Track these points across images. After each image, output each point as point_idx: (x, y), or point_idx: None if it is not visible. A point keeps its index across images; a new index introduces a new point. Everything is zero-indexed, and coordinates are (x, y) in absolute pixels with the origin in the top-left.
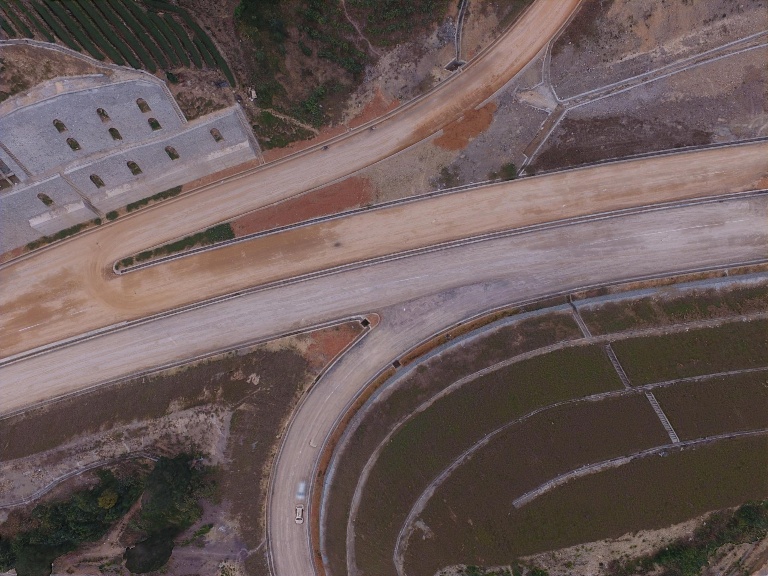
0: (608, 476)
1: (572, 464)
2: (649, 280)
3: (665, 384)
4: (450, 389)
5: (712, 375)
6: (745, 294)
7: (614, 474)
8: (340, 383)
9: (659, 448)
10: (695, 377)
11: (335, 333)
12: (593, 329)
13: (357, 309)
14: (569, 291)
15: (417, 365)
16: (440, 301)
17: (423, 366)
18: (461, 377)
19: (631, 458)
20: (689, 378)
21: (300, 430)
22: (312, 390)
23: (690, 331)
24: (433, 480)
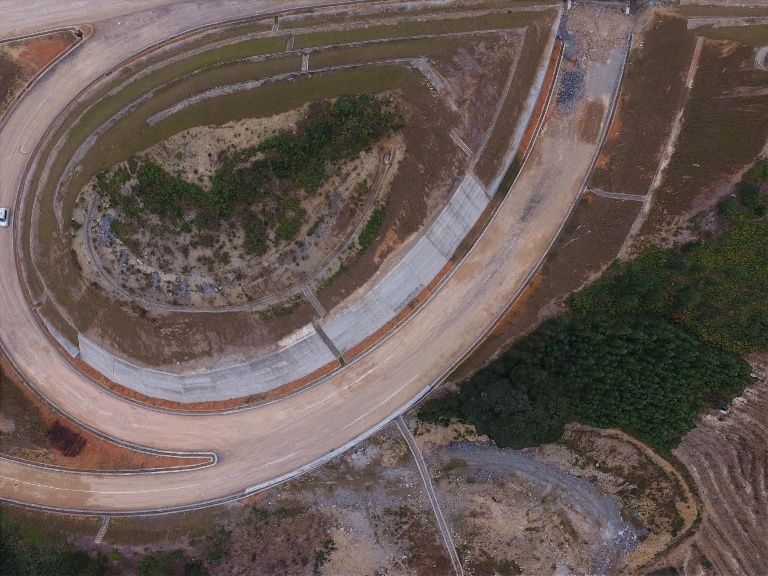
0: (236, 94)
1: (205, 86)
2: (353, 5)
3: (322, 48)
4: (141, 75)
5: (366, 42)
6: (431, 10)
7: (242, 93)
8: (53, 92)
9: (288, 74)
10: (350, 43)
11: (48, 41)
12: (282, 27)
13: (72, 21)
14: (278, 12)
15: (122, 67)
16: (154, 17)
17: (128, 68)
18: (152, 64)
19: (261, 82)
20: (345, 44)
21: (10, 136)
22: (23, 96)
23: (369, 27)
24: (95, 129)
